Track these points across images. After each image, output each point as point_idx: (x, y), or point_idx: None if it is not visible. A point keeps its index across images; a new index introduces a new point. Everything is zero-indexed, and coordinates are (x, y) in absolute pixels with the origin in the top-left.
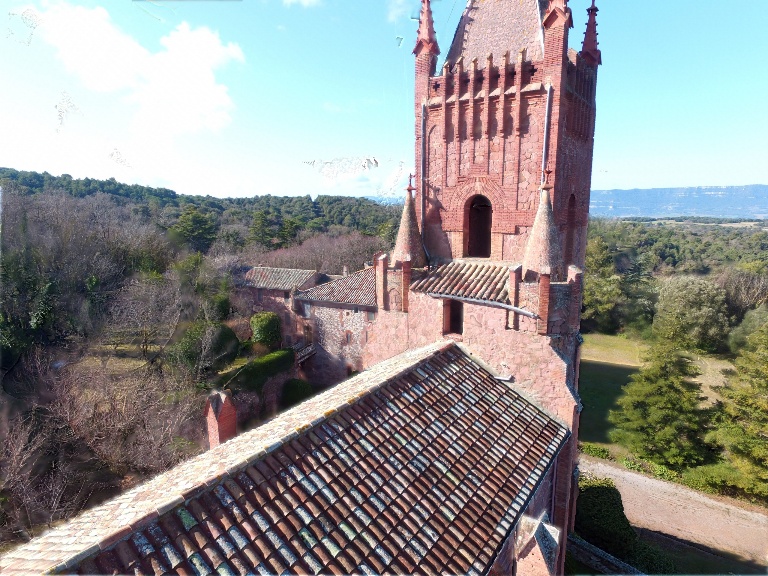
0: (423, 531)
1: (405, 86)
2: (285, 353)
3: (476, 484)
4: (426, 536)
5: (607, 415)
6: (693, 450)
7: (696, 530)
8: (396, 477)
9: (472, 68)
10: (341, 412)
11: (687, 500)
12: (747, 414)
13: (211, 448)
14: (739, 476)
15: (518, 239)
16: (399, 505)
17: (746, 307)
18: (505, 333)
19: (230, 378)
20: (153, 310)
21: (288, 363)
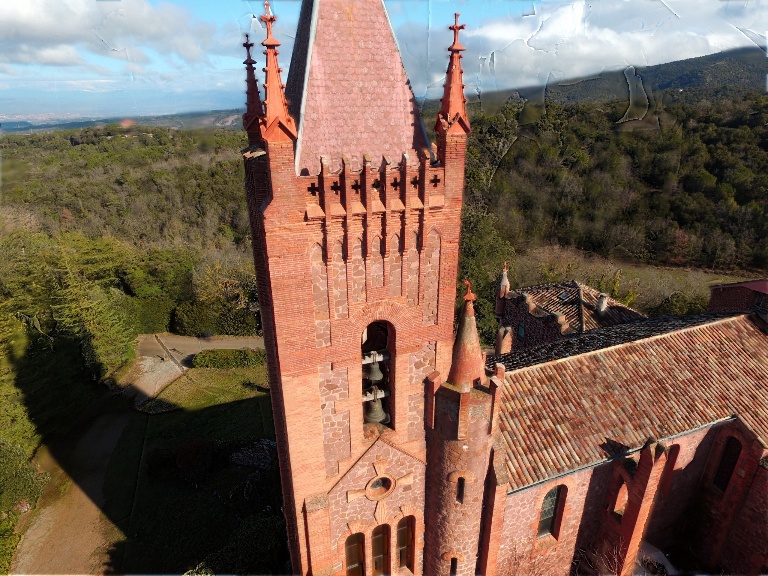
0: None
1: None
2: None
3: None
4: None
5: None
6: None
7: None
8: None
9: None
10: None
11: None
12: None
13: None
14: None
15: None
16: None
17: None
18: None
19: None
20: None
21: None
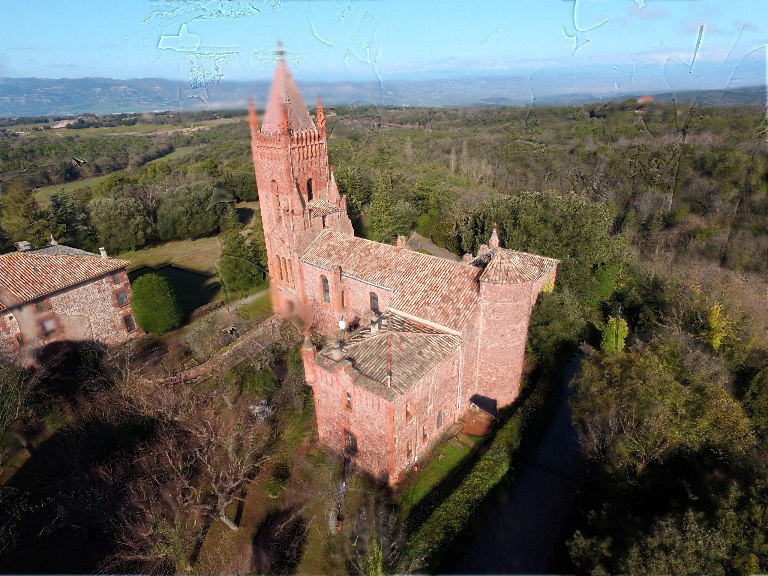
0: None
1: None
2: None
3: None
4: None
5: (189, 292)
6: None
7: None
8: None
9: None
10: None
11: None
12: None
13: None
14: None
15: (322, 191)
16: None
17: (153, 209)
18: (338, 219)
19: None
20: None
21: None
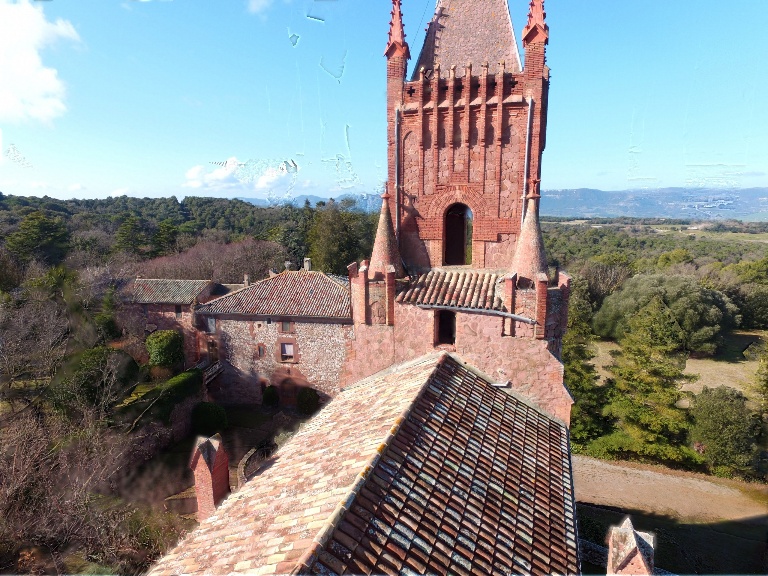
0: (515, 562)
1: (298, 86)
2: (192, 375)
3: (530, 499)
4: (520, 567)
5: None
6: (594, 424)
7: (607, 494)
8: (468, 508)
9: (451, 76)
10: (389, 446)
11: (594, 469)
12: (634, 387)
13: (200, 506)
14: (632, 441)
15: (500, 246)
16: (484, 539)
17: (603, 294)
18: (501, 340)
19: (132, 411)
20: (23, 340)
21: (196, 385)
